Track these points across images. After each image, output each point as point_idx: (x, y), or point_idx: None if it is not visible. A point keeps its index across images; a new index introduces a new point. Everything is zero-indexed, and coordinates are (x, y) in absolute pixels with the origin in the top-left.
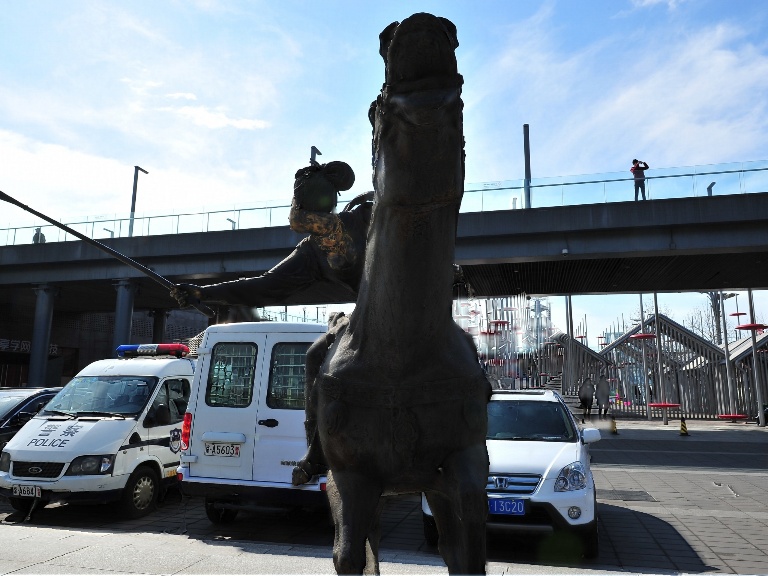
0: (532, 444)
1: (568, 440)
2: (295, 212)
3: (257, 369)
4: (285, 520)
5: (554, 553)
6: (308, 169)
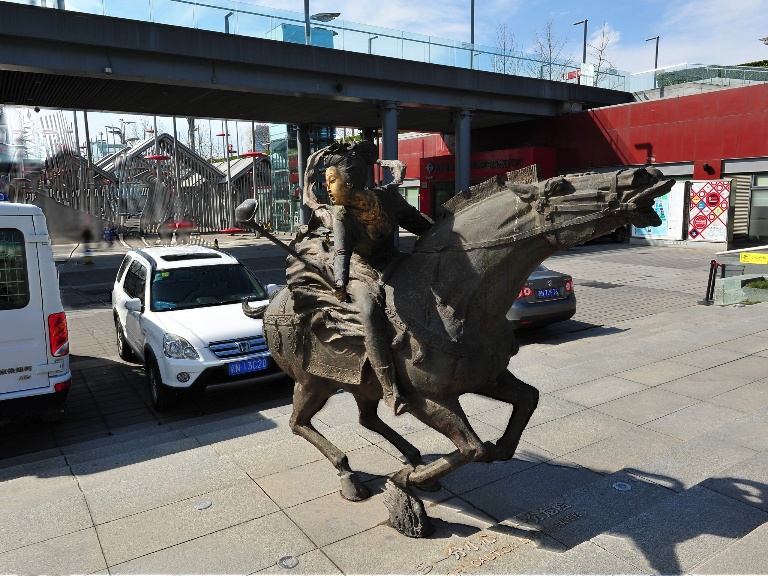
0: (240, 306)
1: (262, 298)
2: (346, 190)
3: None
4: None
5: (266, 389)
6: (348, 146)
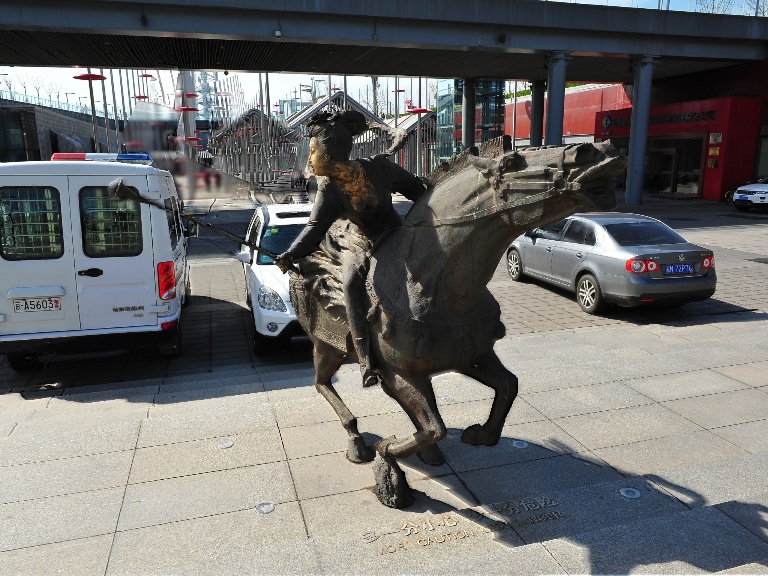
0: None
1: None
2: (324, 161)
3: (64, 217)
4: None
5: None
6: (329, 117)
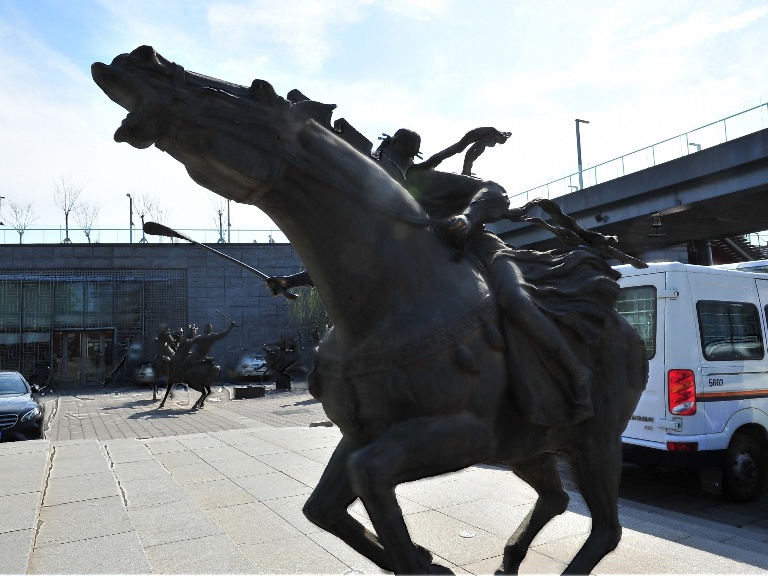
0: None
1: None
2: None
3: None
4: (666, 478)
5: None
6: None
